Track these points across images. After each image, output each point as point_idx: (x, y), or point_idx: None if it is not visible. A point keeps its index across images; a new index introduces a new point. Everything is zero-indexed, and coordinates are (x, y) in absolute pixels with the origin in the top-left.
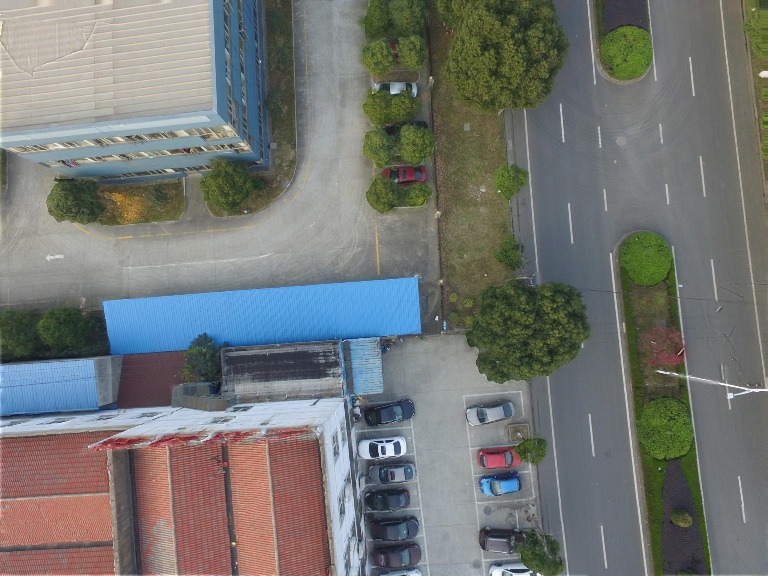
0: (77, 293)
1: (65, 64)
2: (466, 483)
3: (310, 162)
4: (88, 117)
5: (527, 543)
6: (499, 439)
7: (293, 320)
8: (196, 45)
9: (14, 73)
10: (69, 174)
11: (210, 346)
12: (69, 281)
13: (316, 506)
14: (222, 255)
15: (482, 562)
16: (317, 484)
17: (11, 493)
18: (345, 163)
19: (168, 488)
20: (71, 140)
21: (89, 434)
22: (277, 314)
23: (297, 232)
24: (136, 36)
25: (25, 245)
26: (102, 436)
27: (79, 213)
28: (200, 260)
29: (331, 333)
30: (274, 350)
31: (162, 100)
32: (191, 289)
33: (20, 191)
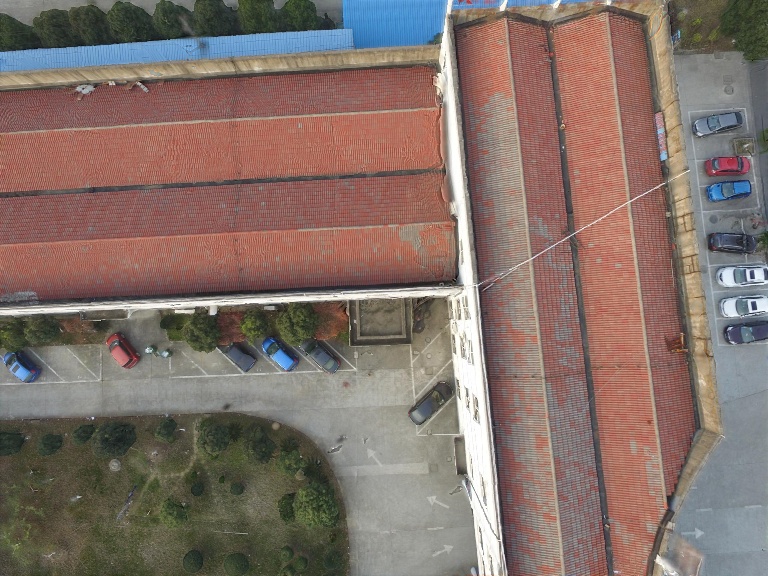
0: None
1: None
2: (692, 193)
3: None
4: None
5: (756, 246)
6: (724, 153)
7: None
8: None
9: None
10: None
11: None
12: None
13: (646, 90)
14: None
15: (708, 268)
16: (646, 70)
17: (305, 111)
18: None
19: (507, 61)
20: None
21: (374, 70)
22: None
23: None
24: None
25: None
26: (388, 71)
27: None
28: None
29: None
30: None
31: None
32: None
33: None
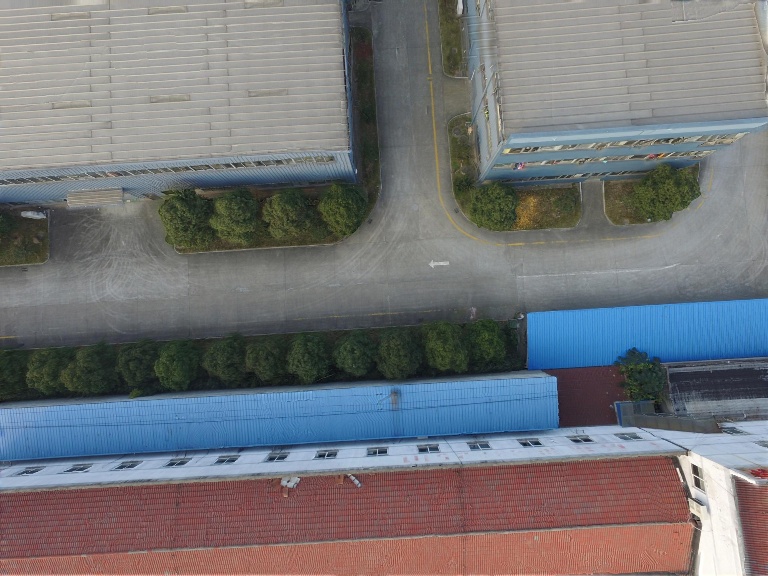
0: (466, 302)
1: (587, 61)
2: None
3: (713, 170)
4: (622, 119)
5: None
6: None
7: (729, 335)
8: (741, 46)
9: (532, 68)
10: (489, 176)
11: (648, 362)
12: (457, 289)
13: None
14: (624, 265)
15: None
16: None
17: (542, 523)
18: (750, 172)
19: None
20: (582, 143)
21: (603, 459)
22: (714, 329)
23: (704, 242)
24: (669, 34)
25: (405, 250)
26: (619, 461)
27: (506, 218)
28: (601, 270)
29: (767, 349)
30: (717, 367)
31: (709, 103)
32: (592, 300)
33: (395, 192)
